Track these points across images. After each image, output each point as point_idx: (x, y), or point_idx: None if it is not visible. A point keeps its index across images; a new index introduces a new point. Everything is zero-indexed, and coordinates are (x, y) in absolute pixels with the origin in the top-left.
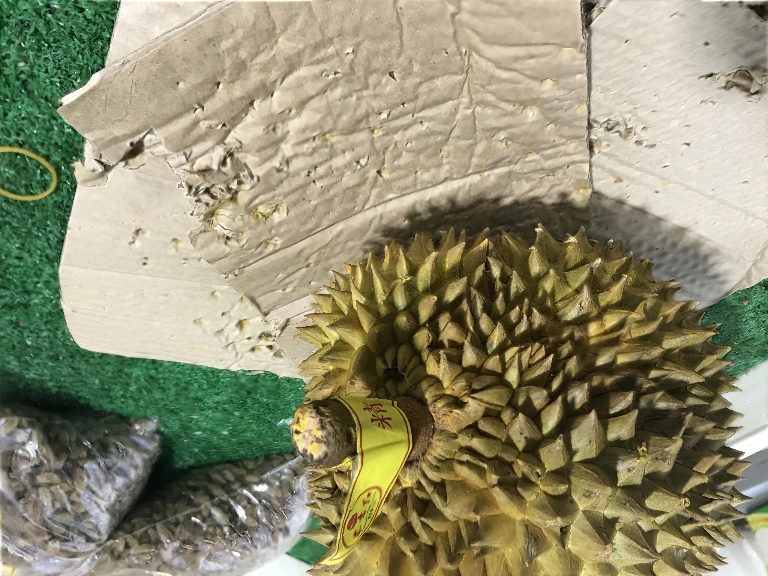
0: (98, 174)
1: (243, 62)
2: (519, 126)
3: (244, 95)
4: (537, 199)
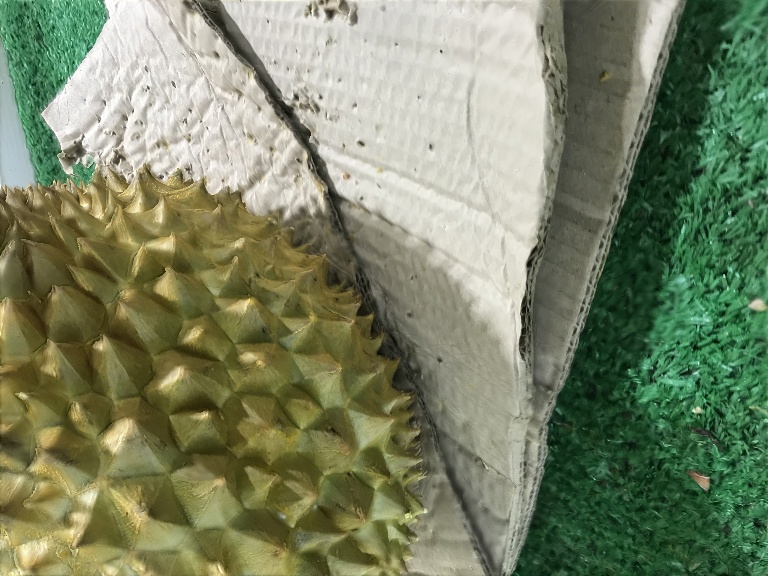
0: (63, 160)
1: (109, 85)
2: (244, 115)
3: (115, 109)
4: (307, 211)
